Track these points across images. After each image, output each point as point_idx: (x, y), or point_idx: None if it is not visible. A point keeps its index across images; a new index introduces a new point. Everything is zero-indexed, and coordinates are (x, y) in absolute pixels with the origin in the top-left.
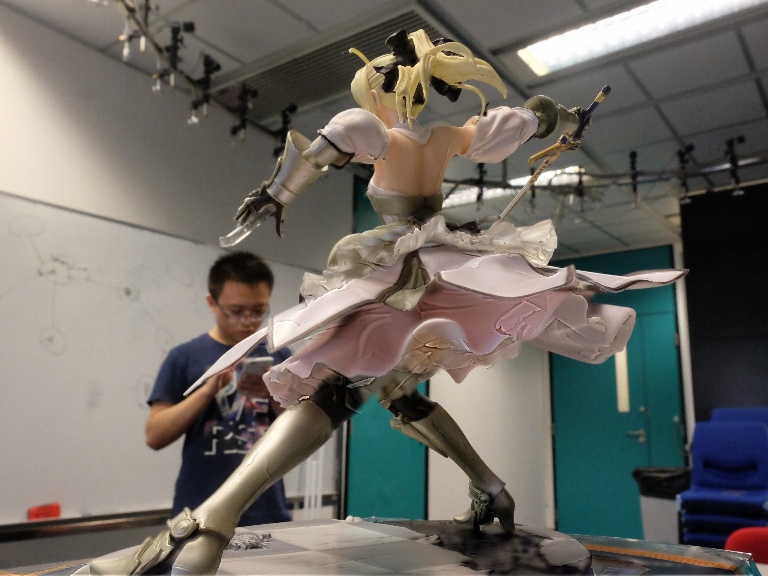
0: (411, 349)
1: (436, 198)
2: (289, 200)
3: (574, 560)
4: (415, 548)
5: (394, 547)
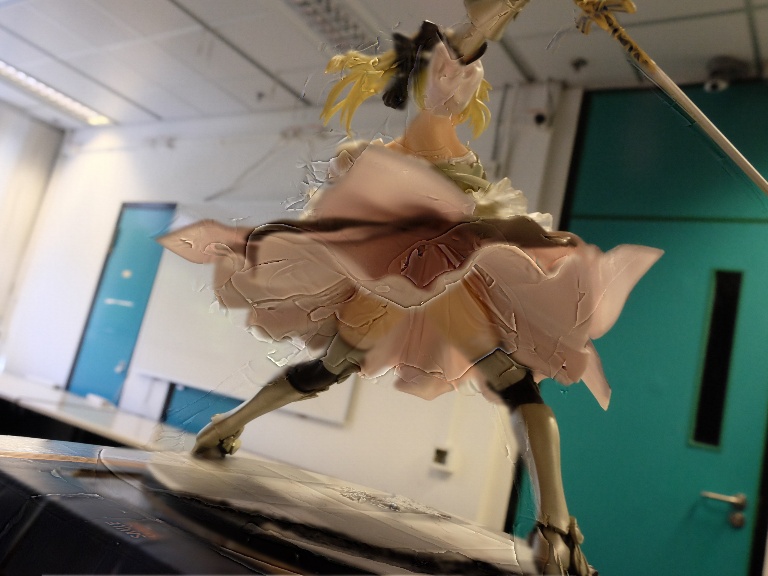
0: (222, 302)
1: None
2: None
3: (308, 549)
4: (399, 540)
5: None
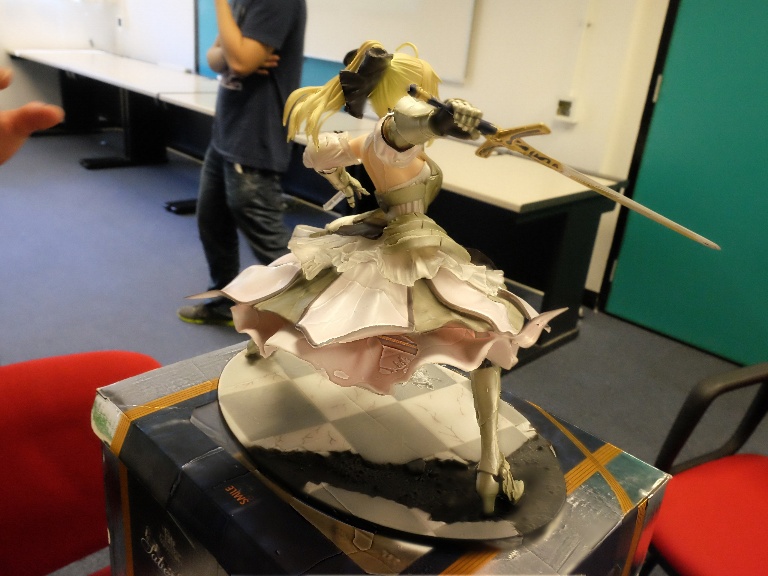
0: None
1: (386, 195)
2: (337, 187)
3: (342, 501)
4: (418, 446)
5: (422, 437)
